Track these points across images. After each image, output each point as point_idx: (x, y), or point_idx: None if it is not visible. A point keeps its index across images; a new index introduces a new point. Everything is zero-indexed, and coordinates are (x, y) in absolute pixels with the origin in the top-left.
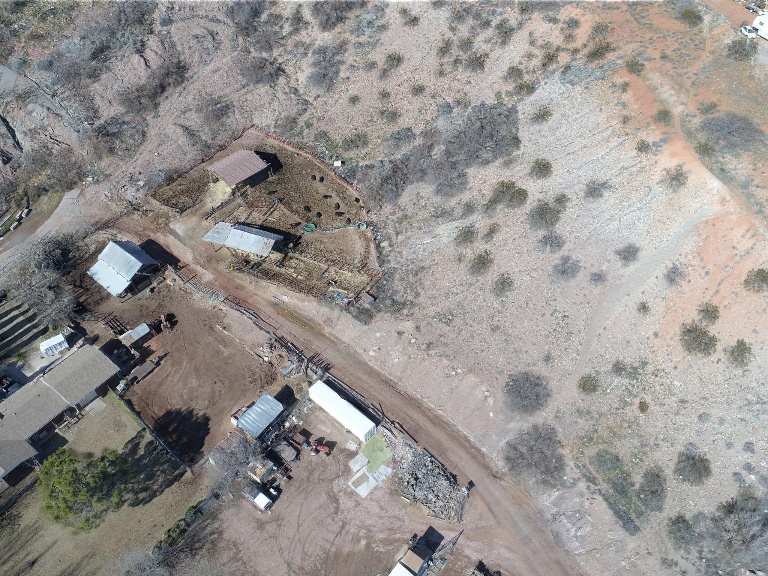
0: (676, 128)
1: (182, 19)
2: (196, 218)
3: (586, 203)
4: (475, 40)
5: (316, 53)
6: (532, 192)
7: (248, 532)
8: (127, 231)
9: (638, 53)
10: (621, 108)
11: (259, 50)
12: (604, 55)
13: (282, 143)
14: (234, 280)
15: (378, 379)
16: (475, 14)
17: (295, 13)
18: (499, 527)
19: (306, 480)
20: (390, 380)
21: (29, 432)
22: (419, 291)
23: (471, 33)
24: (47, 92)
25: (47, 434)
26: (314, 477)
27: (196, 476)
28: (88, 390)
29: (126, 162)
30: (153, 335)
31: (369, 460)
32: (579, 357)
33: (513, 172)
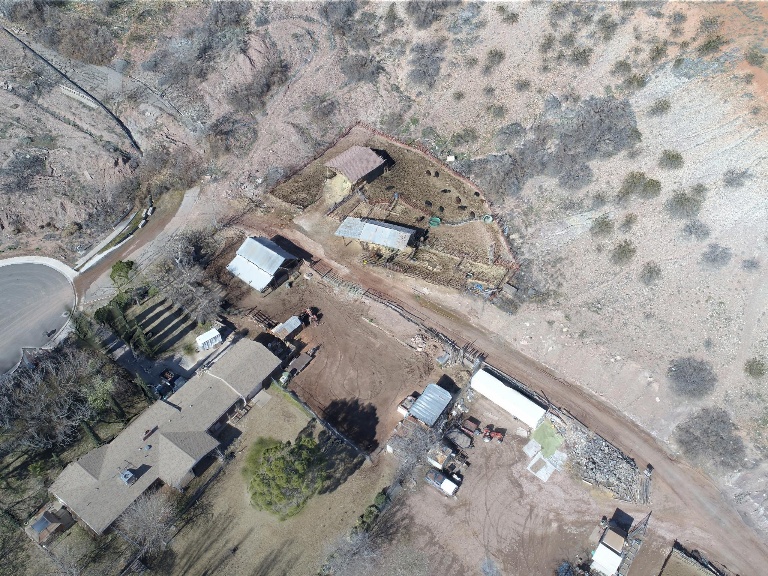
0: None
1: (278, 19)
2: (319, 214)
3: (727, 192)
4: (577, 35)
5: (414, 51)
6: (665, 183)
7: (439, 517)
8: (254, 227)
9: (755, 45)
10: (748, 99)
11: (356, 48)
12: (718, 48)
13: (390, 139)
14: (370, 274)
15: (534, 367)
16: (575, 10)
17: (389, 12)
18: (687, 508)
19: (485, 466)
20: (546, 368)
21: (207, 423)
22: (561, 281)
23: (573, 29)
24: (156, 92)
25: (220, 425)
26: (492, 463)
27: (375, 464)
28: (256, 382)
29: (242, 160)
30: (302, 328)
31: (542, 446)
32: (741, 342)
33: (641, 164)
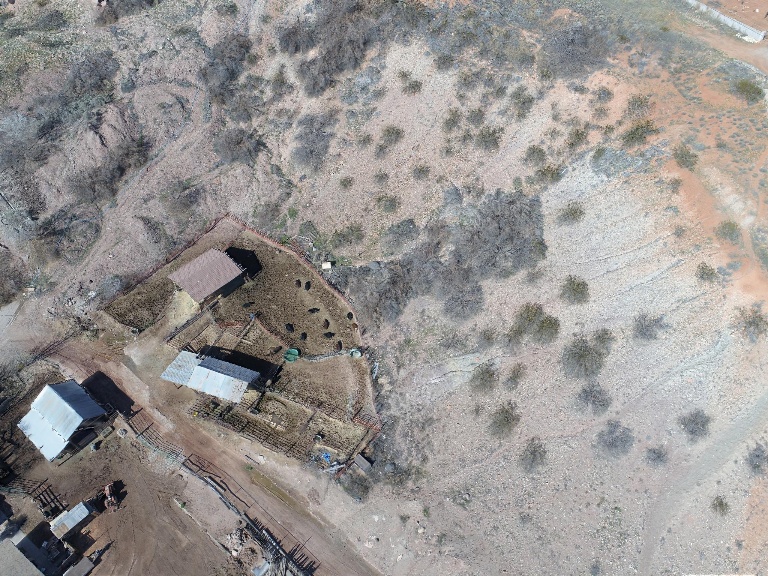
0: (747, 249)
1: (147, 83)
2: (156, 340)
3: (636, 346)
4: (487, 111)
5: (302, 123)
6: (565, 322)
7: None
8: (72, 360)
9: (688, 139)
10: (673, 214)
11: (236, 120)
12: (645, 138)
13: (262, 236)
14: (199, 431)
15: None
16: (487, 79)
17: (278, 75)
18: None
19: None
20: None
21: None
22: (427, 454)
23: (482, 103)
24: None
25: None
26: None
27: None
28: None
29: (75, 266)
30: (94, 516)
31: None
32: (638, 571)
33: (540, 292)
